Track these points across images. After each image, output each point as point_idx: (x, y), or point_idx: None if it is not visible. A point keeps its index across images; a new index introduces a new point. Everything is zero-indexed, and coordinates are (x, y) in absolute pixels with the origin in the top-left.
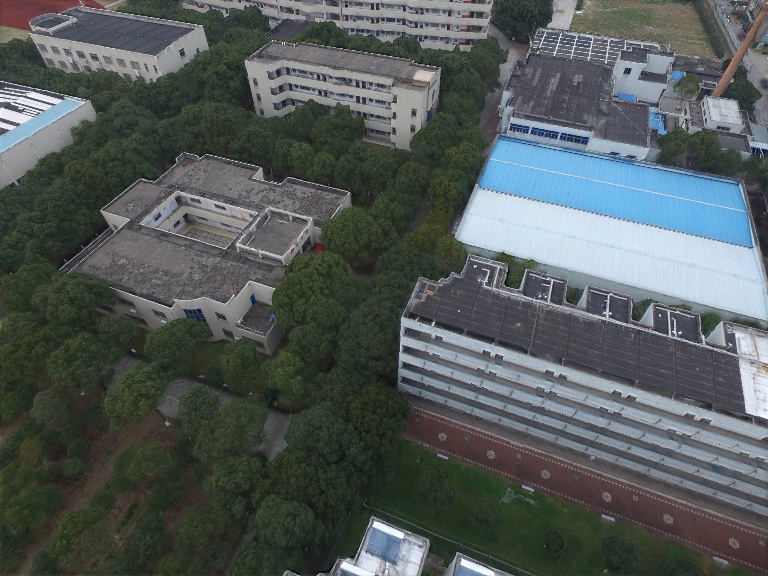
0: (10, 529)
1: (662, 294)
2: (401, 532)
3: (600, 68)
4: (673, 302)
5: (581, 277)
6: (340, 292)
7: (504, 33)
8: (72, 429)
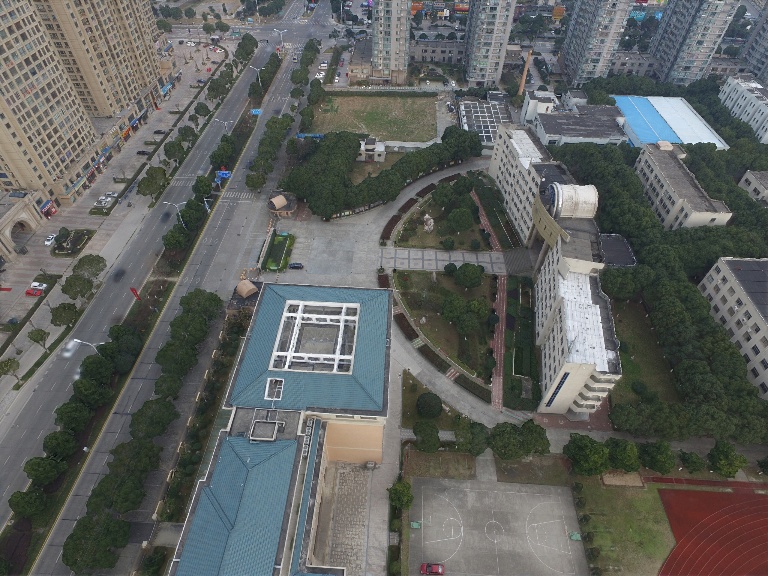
0: None
1: None
2: None
3: (541, 115)
4: None
5: None
6: None
7: (449, 167)
8: None
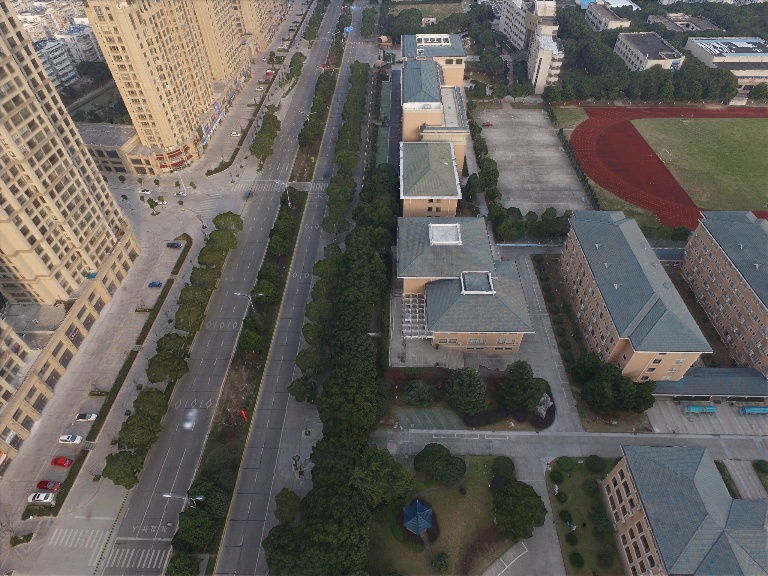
0: None
1: None
2: None
3: None
4: None
5: None
6: None
7: None
8: None
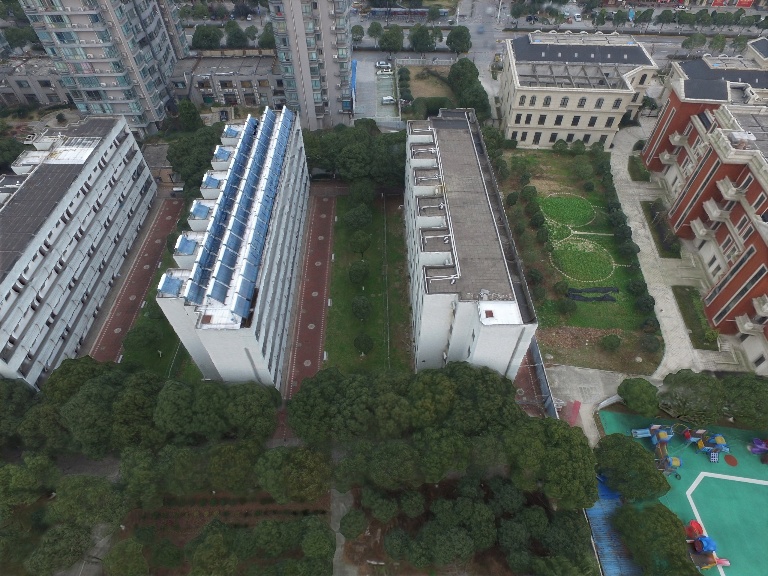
0: None
1: None
2: (163, 275)
3: None
4: None
5: None
6: None
7: None
8: None
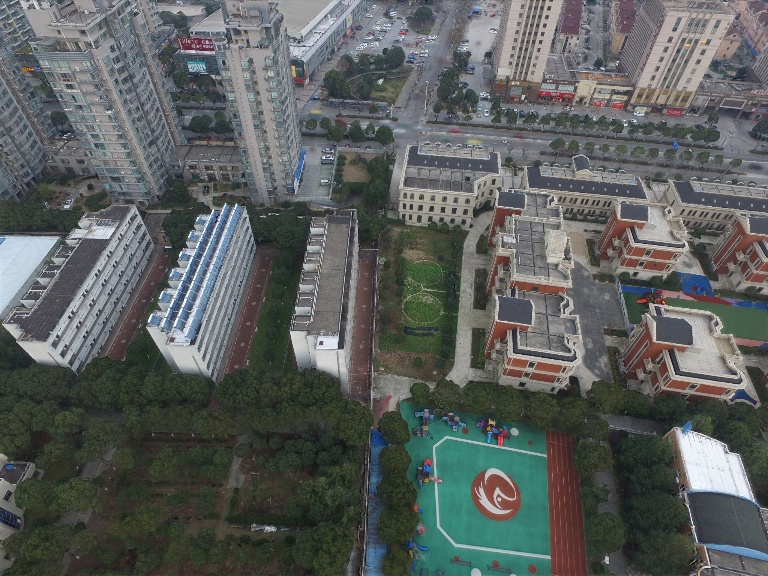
0: (162, 512)
1: (34, 271)
2: (151, 315)
3: None
4: (39, 269)
5: (12, 304)
6: (8, 403)
7: None
8: (100, 547)
